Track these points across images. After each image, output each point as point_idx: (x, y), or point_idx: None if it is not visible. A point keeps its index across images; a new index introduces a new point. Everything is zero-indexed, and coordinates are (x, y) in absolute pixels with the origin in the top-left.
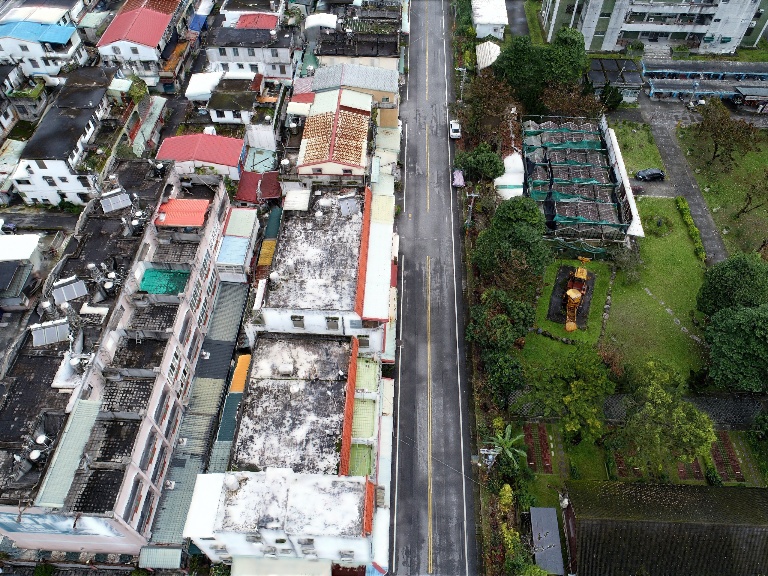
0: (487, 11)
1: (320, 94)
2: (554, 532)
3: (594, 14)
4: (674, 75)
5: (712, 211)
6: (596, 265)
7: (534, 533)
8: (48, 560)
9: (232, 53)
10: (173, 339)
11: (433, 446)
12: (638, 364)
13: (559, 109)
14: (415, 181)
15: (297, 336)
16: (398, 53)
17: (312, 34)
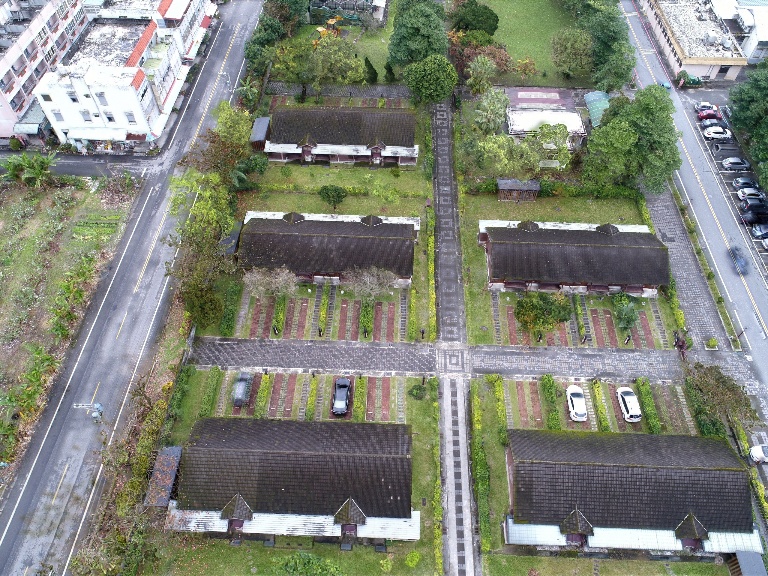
0: None
1: None
2: (265, 125)
3: None
4: None
5: (447, 3)
6: (353, 28)
7: (254, 127)
8: None
9: None
10: (40, 18)
11: (211, 102)
12: None
13: None
14: None
15: (119, 21)
16: None
17: None
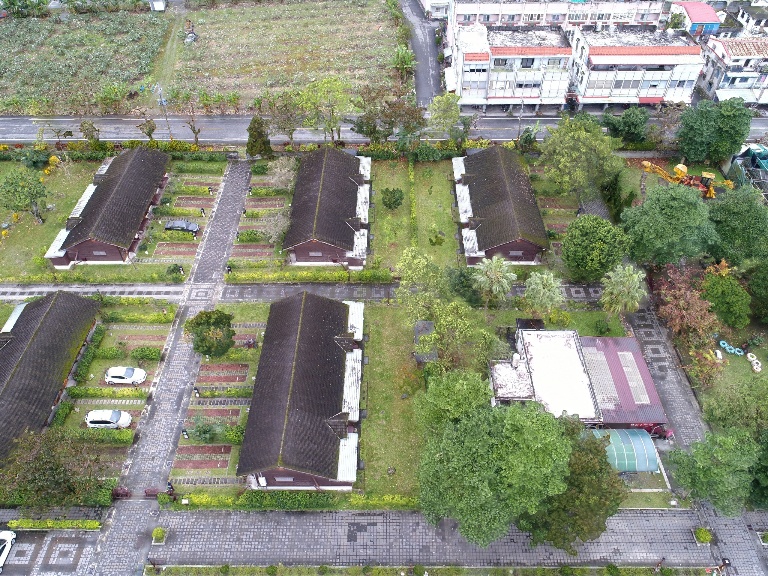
0: None
1: None
2: None
3: None
4: None
5: None
6: None
7: None
8: (443, 37)
9: None
10: (544, 6)
11: None
12: None
13: None
14: None
15: None
16: None
17: None
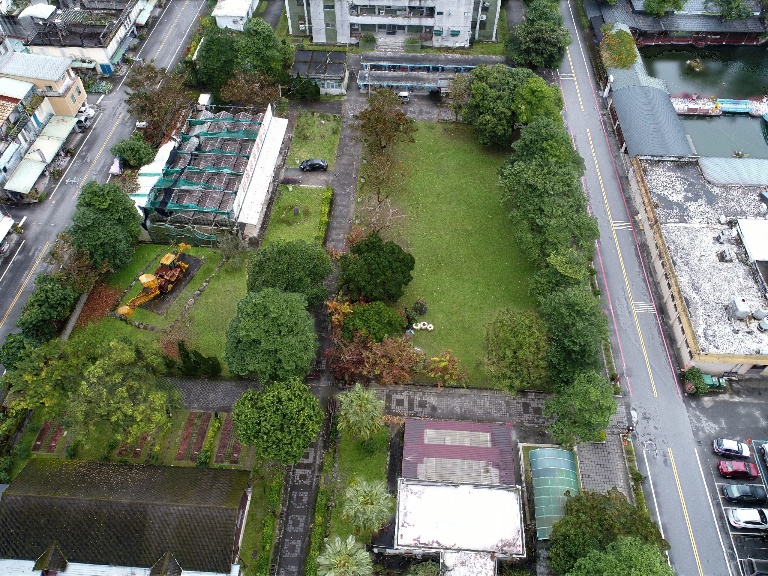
0: (231, 3)
1: None
2: None
3: (317, 6)
4: (394, 68)
5: (357, 201)
6: (211, 252)
7: None
8: None
9: None
10: None
11: None
12: (198, 349)
13: (233, 99)
14: (78, 169)
15: None
16: (103, 43)
17: (26, 24)
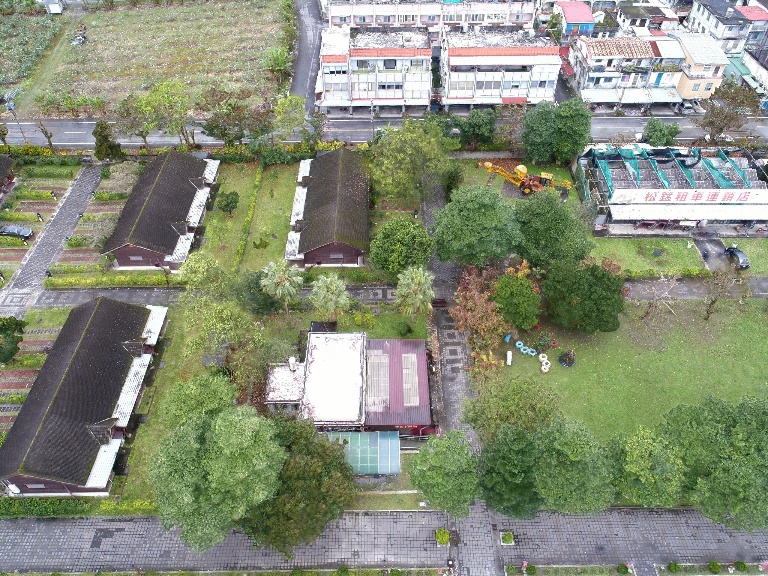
0: None
1: (667, 37)
2: None
3: None
4: None
5: (704, 300)
6: None
7: None
8: None
9: (702, 12)
10: (417, 7)
11: None
12: None
13: None
14: (631, 122)
15: None
16: None
17: None
